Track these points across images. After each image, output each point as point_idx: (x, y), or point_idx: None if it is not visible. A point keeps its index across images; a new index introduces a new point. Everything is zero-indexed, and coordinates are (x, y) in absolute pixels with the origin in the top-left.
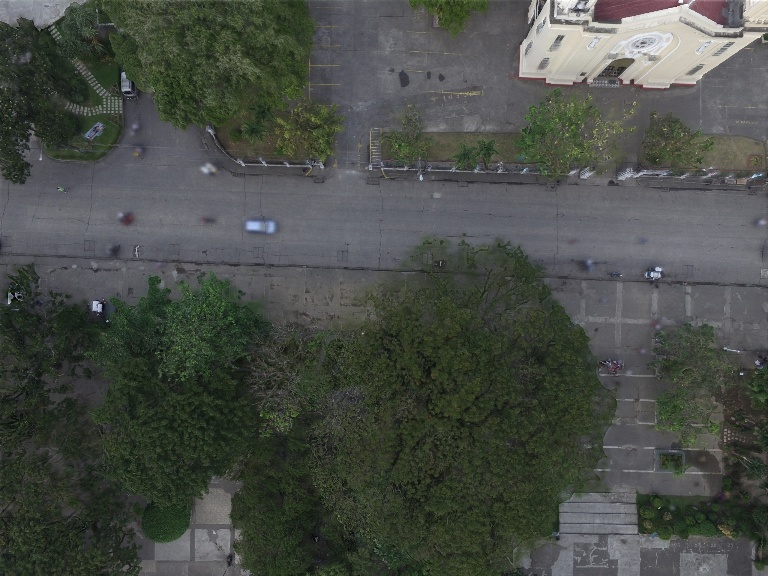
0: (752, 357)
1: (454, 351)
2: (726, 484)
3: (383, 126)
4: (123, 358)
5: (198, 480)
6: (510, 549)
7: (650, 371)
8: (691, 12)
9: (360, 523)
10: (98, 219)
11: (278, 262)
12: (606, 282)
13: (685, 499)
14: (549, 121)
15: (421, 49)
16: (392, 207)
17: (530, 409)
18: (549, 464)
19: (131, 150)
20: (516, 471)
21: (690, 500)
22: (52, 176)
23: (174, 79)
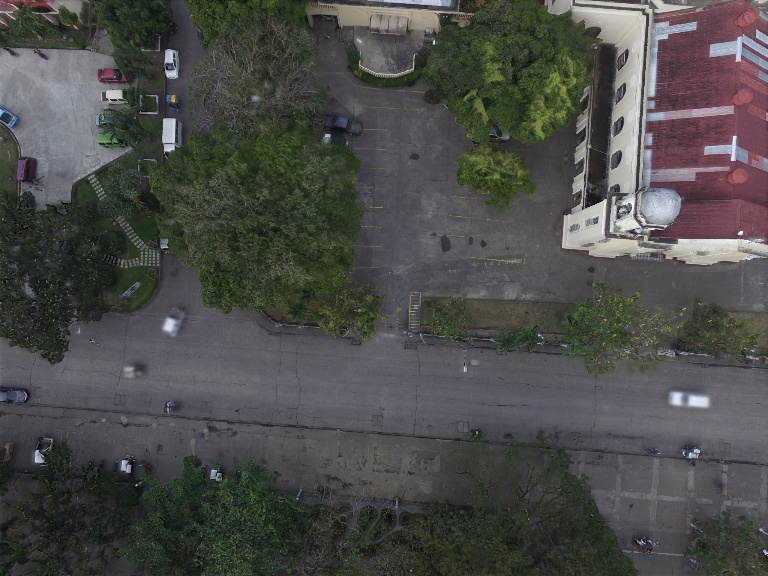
0: None
1: None
2: None
3: (423, 290)
4: (158, 559)
5: None
6: None
7: (685, 551)
8: (750, 244)
9: None
10: (130, 373)
11: (312, 424)
12: (643, 457)
13: None
14: (598, 322)
15: (464, 214)
16: (429, 373)
17: None
18: None
19: (167, 304)
20: None
21: None
22: (85, 327)
23: (223, 279)
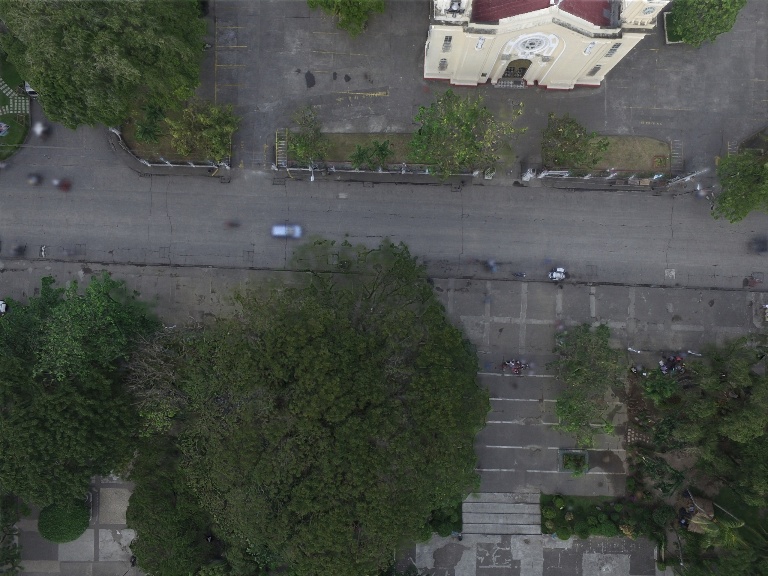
0: (656, 357)
1: (316, 351)
2: (630, 484)
3: (289, 126)
4: (5, 358)
5: (75, 480)
6: (376, 549)
7: (554, 371)
8: (563, 13)
9: (233, 523)
10: (4, 219)
11: (184, 262)
12: (511, 282)
13: (589, 499)
14: (436, 122)
15: (327, 50)
16: (298, 207)
17: (393, 409)
18: (411, 464)
19: (38, 150)
20: (377, 471)
21: (594, 500)
22: None
23: (54, 79)
